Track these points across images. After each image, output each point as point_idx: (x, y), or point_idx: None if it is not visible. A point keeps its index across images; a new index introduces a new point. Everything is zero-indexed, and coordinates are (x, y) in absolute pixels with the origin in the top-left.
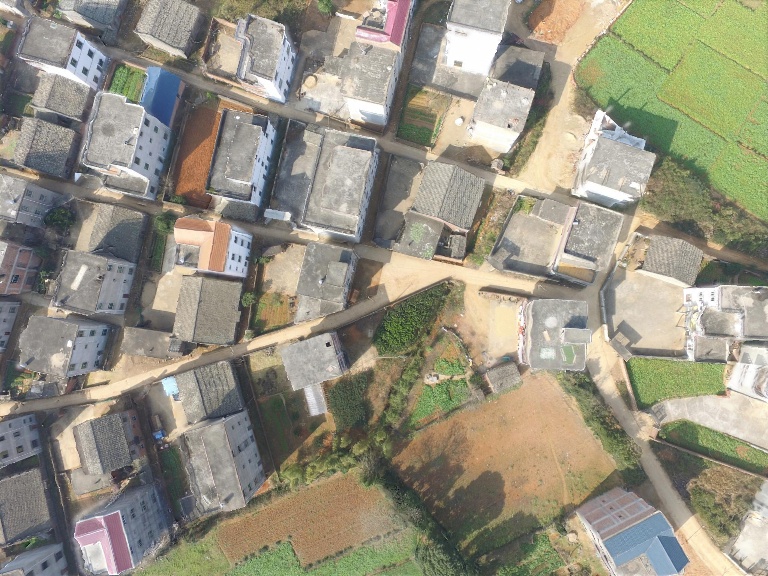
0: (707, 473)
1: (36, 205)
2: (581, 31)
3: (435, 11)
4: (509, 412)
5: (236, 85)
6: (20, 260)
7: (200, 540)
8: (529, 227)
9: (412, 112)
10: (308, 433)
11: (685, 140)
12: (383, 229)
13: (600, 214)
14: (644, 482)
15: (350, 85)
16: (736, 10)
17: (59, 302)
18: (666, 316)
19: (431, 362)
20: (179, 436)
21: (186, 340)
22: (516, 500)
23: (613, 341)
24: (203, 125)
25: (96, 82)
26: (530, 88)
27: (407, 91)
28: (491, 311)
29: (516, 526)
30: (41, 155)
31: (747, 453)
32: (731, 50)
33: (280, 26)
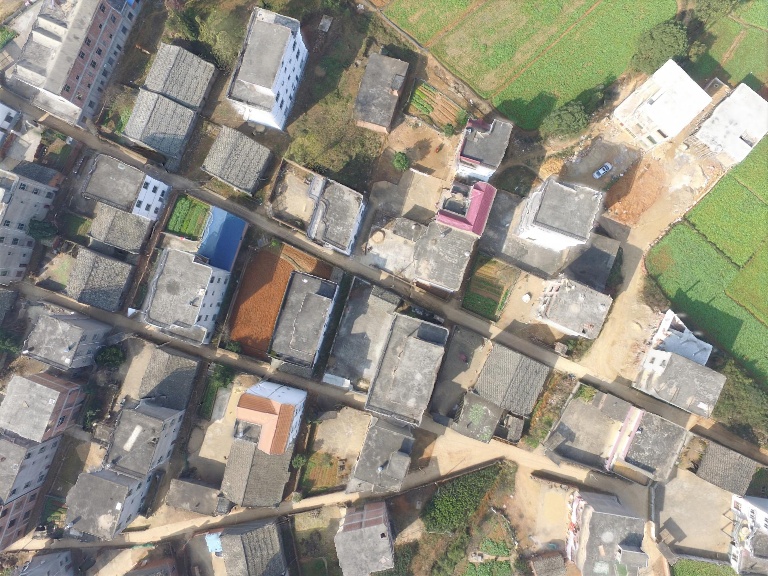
0: None
1: (89, 346)
2: (656, 215)
3: (511, 177)
4: None
5: (301, 231)
6: (68, 401)
7: None
8: (586, 414)
9: (479, 281)
10: None
11: (748, 340)
12: (440, 399)
13: (663, 425)
14: None
15: (426, 267)
16: None
17: (111, 464)
18: (712, 518)
19: (477, 541)
20: None
21: (234, 502)
22: None
23: (660, 544)
24: (264, 270)
25: (156, 212)
26: (608, 295)
27: (476, 259)
28: (541, 495)
29: None
30: (96, 291)
31: None
32: None
33: (358, 194)
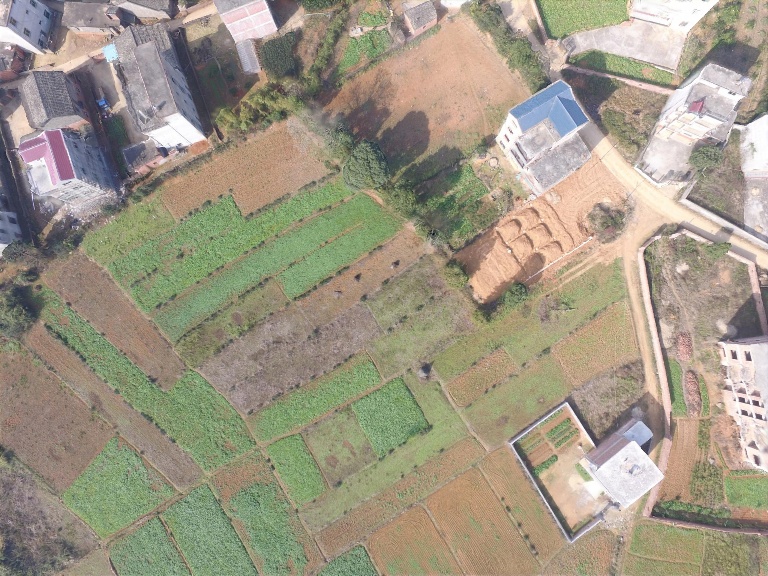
0: (616, 96)
1: None
2: None
3: None
4: (429, 56)
5: None
6: None
7: (146, 201)
8: None
9: None
10: (243, 93)
11: None
12: None
13: None
14: None
15: None
16: None
17: None
18: None
19: (355, 16)
20: (122, 108)
21: (122, 2)
22: (440, 136)
23: None
24: None
25: None
26: None
27: None
28: None
29: (441, 160)
30: None
31: (651, 73)
32: None
33: None
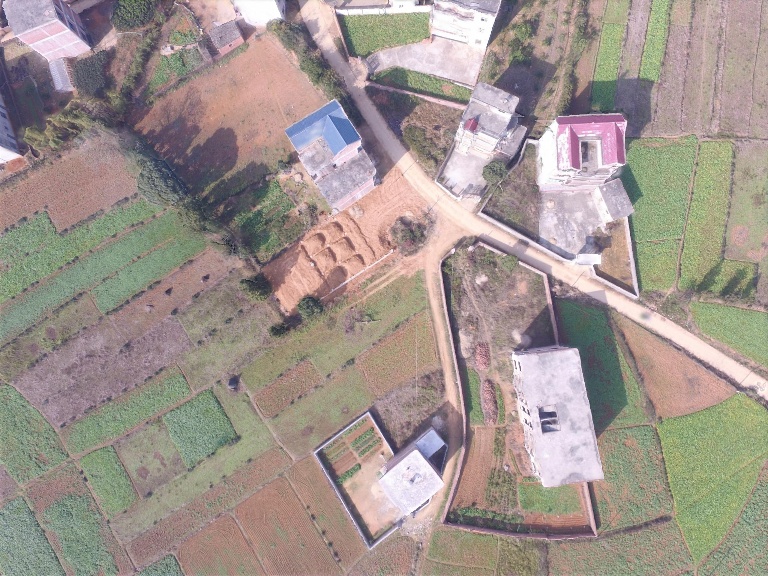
0: (418, 112)
1: None
2: None
3: None
4: (238, 73)
5: None
6: None
7: None
8: None
9: None
10: (58, 111)
11: None
12: None
13: None
14: (362, 125)
15: None
16: None
17: None
18: None
19: (166, 35)
20: None
21: None
22: (248, 152)
23: None
24: None
25: None
26: None
27: None
28: None
29: (249, 175)
30: None
31: (451, 89)
32: None
33: None
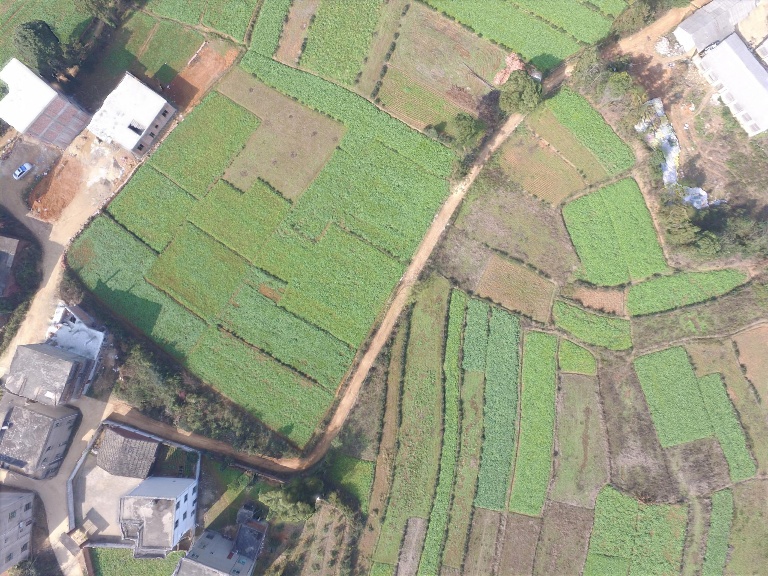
0: None
1: None
2: (76, 210)
3: None
4: None
5: None
6: None
7: None
8: None
9: None
10: None
11: (167, 323)
12: None
13: (33, 417)
14: None
15: None
16: (226, 192)
17: None
18: None
19: None
20: None
21: None
22: None
23: (63, 536)
24: None
25: None
26: None
27: None
28: None
29: None
30: None
31: None
32: (219, 232)
33: None
